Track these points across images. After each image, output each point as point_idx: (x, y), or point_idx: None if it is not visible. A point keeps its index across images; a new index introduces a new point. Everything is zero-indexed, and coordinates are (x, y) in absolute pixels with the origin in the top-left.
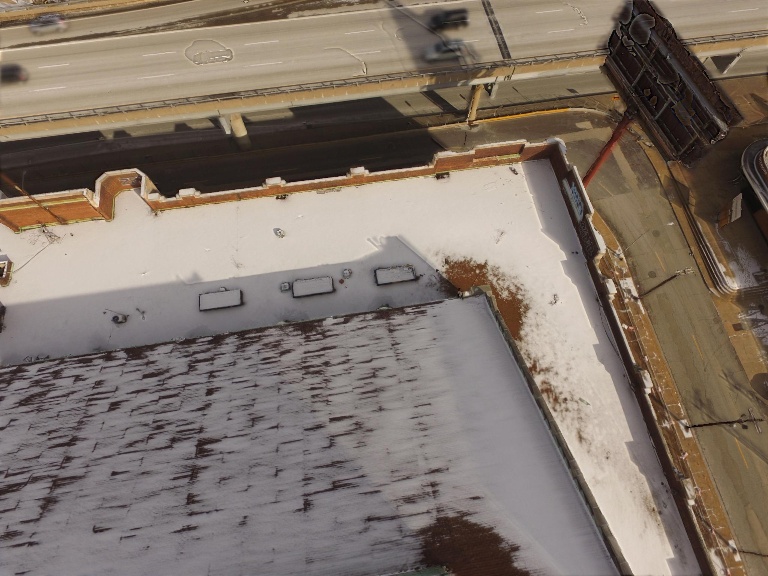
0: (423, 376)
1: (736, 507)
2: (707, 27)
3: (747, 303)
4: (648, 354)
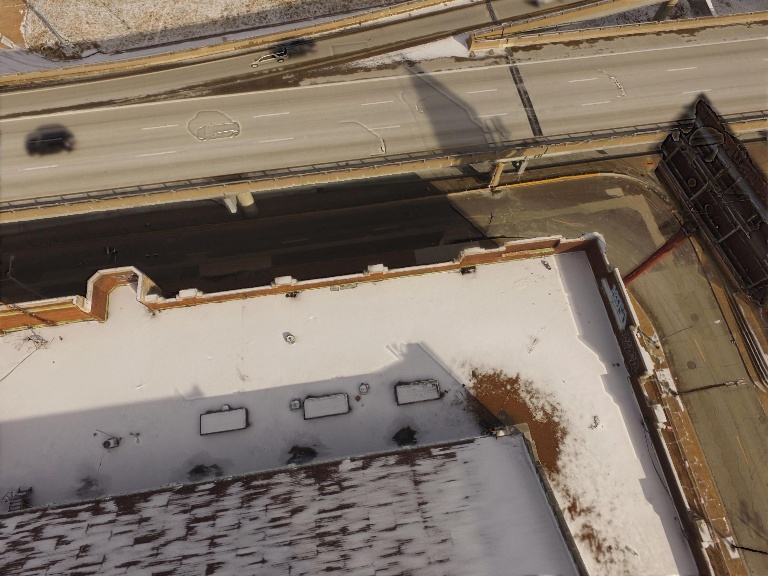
0: (456, 555)
1: None
2: (755, 100)
3: None
4: (689, 459)
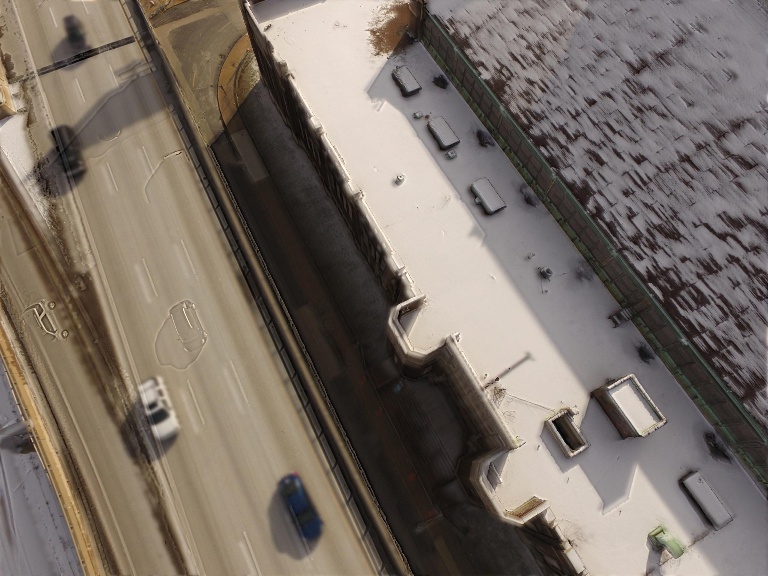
0: None
1: None
2: None
3: None
4: None
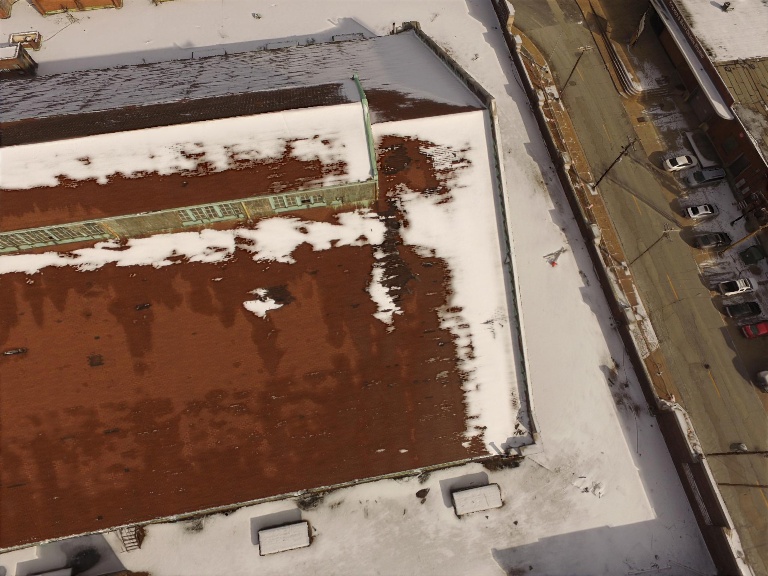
0: (360, 57)
1: (629, 240)
2: None
3: (650, 103)
4: (565, 138)
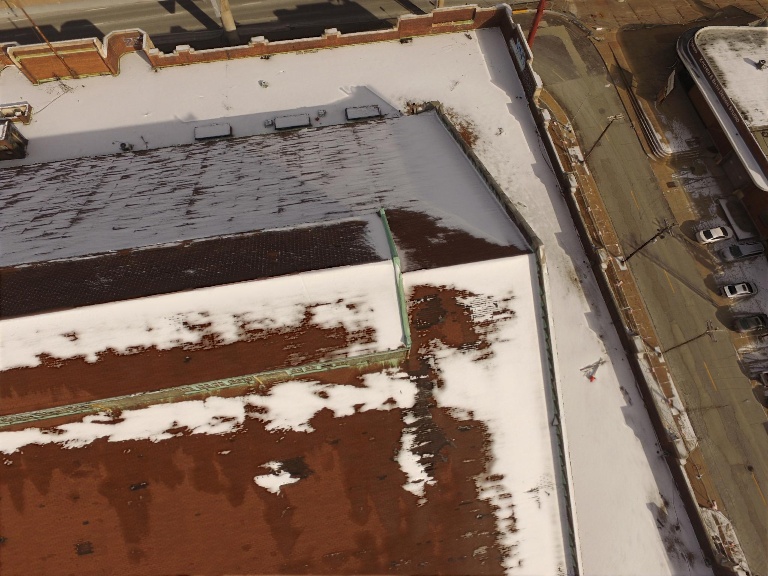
0: (379, 151)
1: (663, 322)
2: None
3: (680, 165)
4: (591, 206)
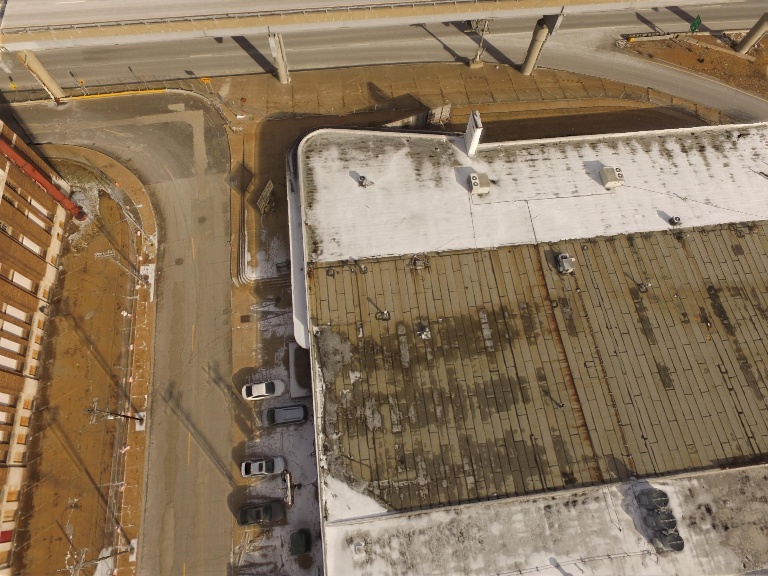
0: None
1: (157, 505)
2: (227, 4)
3: (265, 295)
4: (136, 343)
